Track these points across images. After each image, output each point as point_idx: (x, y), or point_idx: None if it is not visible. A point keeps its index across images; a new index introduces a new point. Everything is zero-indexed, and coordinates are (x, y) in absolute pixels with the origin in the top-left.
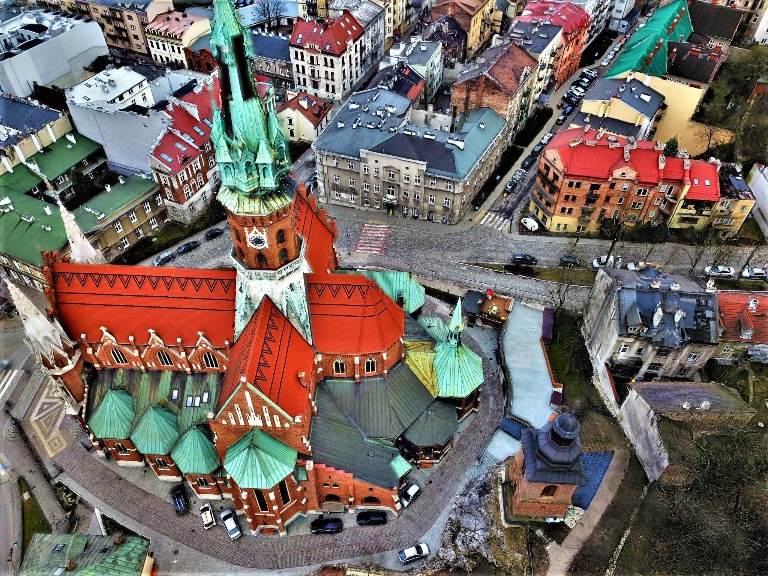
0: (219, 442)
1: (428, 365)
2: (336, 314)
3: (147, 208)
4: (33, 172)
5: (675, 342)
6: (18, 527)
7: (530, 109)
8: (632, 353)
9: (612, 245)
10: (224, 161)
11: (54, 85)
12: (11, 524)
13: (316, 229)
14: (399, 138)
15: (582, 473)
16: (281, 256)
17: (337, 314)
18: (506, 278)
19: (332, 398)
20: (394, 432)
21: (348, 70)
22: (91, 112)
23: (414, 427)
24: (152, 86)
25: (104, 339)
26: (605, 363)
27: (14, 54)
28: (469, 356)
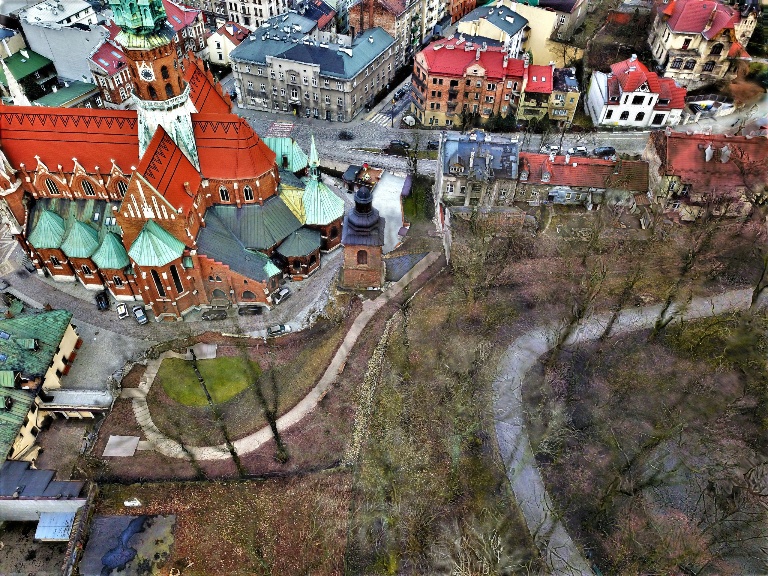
0: (125, 237)
1: (298, 200)
2: (217, 146)
3: None
4: None
5: (484, 178)
6: None
7: (425, 37)
8: (457, 192)
9: (463, 126)
10: (115, 3)
11: (11, 13)
12: None
13: (213, 98)
14: (299, 47)
15: (381, 238)
16: (168, 91)
17: (218, 146)
18: (382, 157)
19: (219, 219)
20: (267, 244)
21: (275, 8)
22: (41, 29)
23: (284, 244)
24: (99, 17)
25: (39, 168)
26: (440, 203)
27: None
28: (331, 194)
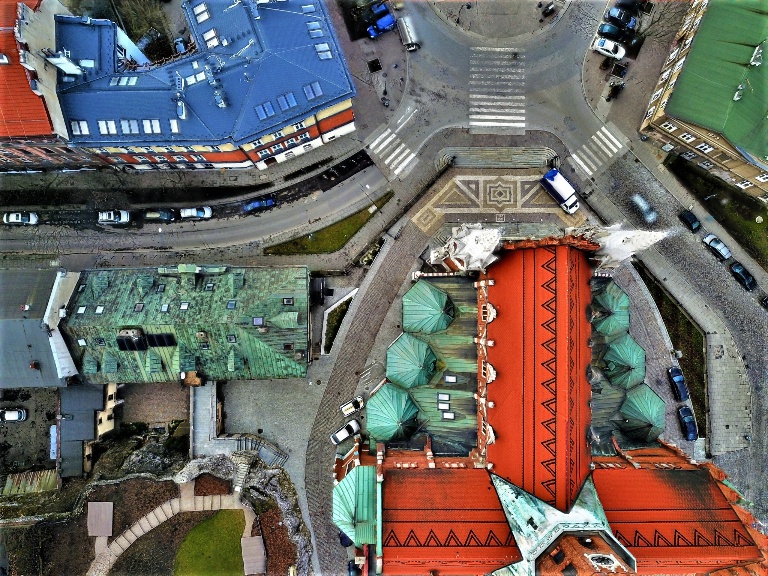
0: None
1: None
2: None
3: None
4: None
5: None
6: (341, 215)
7: None
8: None
9: None
10: None
11: None
12: (344, 206)
13: (700, 567)
14: None
15: None
16: None
17: None
18: None
19: None
20: None
21: None
22: None
23: None
24: None
25: None
26: None
27: None
28: None
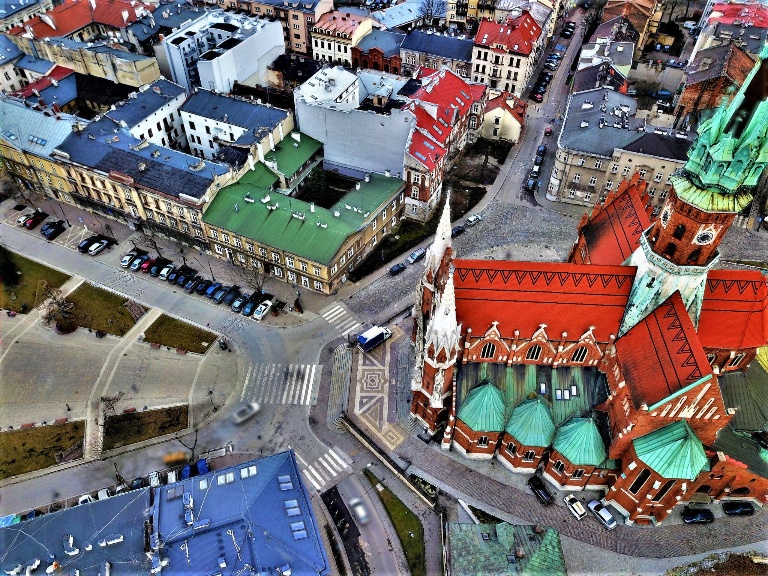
0: (629, 434)
1: None
2: (724, 309)
3: (393, 206)
4: (270, 170)
5: None
6: (385, 518)
7: None
8: None
9: None
10: (724, 160)
11: (258, 84)
12: (376, 515)
13: None
14: (650, 137)
15: None
16: None
17: (725, 309)
18: None
19: None
20: (760, 425)
21: (528, 70)
22: (323, 111)
23: None
24: None
25: (489, 334)
26: None
27: (220, 53)
28: None
